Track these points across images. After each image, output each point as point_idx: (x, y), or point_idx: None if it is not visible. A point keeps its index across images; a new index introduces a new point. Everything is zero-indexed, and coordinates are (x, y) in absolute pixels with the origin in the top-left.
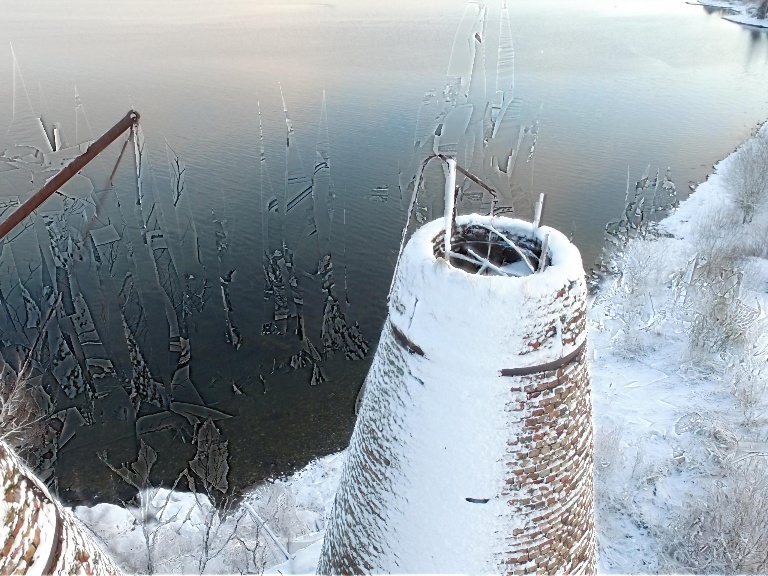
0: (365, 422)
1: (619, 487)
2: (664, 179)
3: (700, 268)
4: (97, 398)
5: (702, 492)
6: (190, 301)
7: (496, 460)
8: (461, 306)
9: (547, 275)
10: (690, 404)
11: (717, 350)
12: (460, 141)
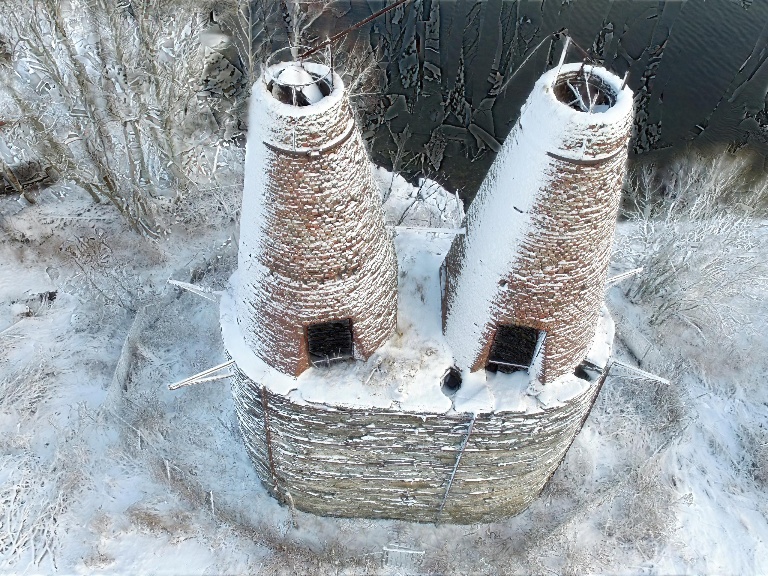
0: None
1: None
2: None
3: None
4: None
5: None
6: None
7: (532, 194)
8: (541, 113)
9: (591, 115)
10: None
11: None
12: None
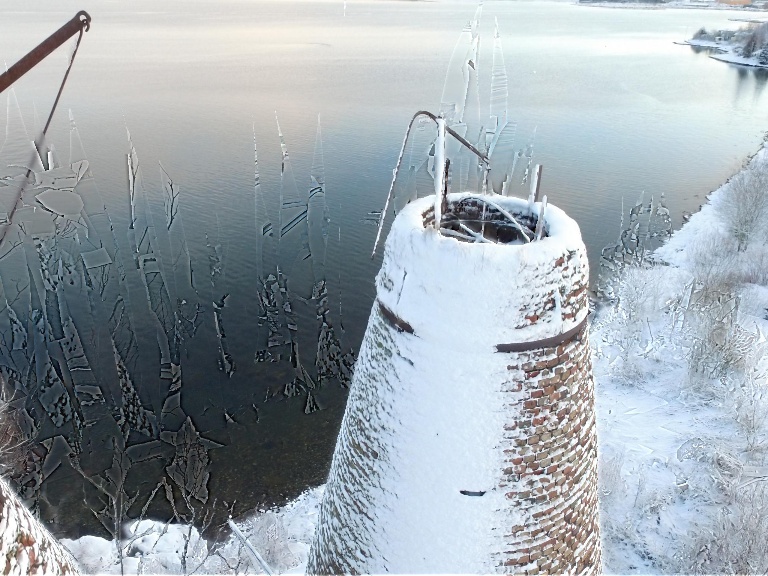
0: (352, 413)
1: (622, 516)
2: (658, 205)
3: (697, 293)
4: (85, 427)
5: (707, 521)
6: (182, 326)
7: (492, 447)
8: (452, 275)
9: (544, 243)
10: (692, 431)
11: (717, 376)
12: (454, 161)
